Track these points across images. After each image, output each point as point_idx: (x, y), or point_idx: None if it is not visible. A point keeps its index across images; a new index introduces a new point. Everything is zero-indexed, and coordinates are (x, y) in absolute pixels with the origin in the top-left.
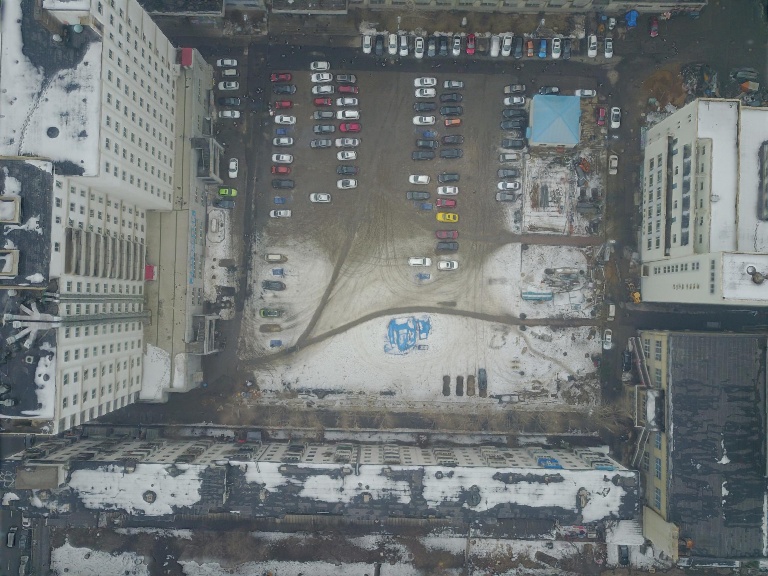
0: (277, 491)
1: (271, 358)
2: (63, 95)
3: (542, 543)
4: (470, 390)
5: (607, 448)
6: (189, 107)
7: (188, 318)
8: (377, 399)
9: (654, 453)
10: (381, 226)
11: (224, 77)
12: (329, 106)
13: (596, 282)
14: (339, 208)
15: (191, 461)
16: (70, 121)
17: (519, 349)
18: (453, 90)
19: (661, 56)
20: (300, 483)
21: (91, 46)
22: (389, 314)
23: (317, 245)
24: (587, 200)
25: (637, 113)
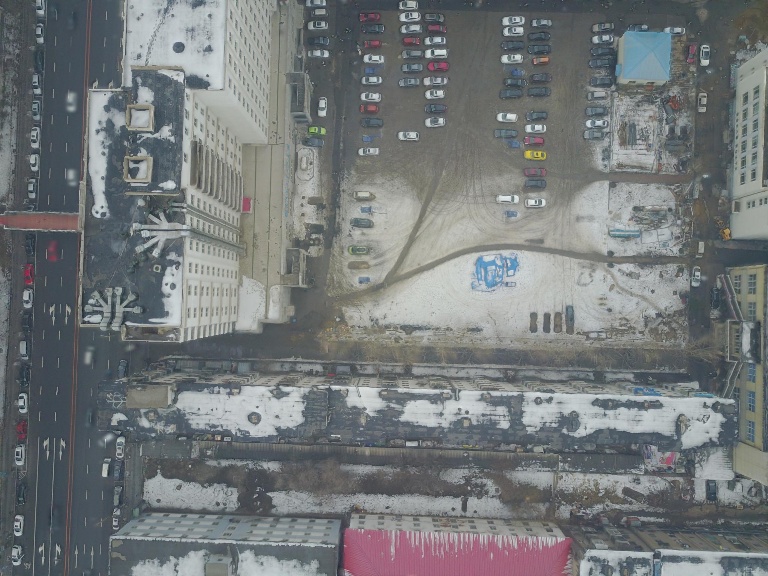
0: (378, 415)
1: (359, 294)
2: (188, 11)
3: (629, 479)
4: (557, 327)
5: (696, 384)
6: (284, 43)
7: (283, 250)
8: (464, 335)
9: (746, 387)
10: (468, 164)
11: (313, 17)
12: (417, 45)
13: (684, 220)
14: (427, 146)
15: (293, 385)
16: (195, 36)
17: (606, 286)
18: (541, 29)
19: None
20: (400, 408)
21: None
22: (476, 251)
23: (405, 183)
24: (675, 138)
25: (726, 51)
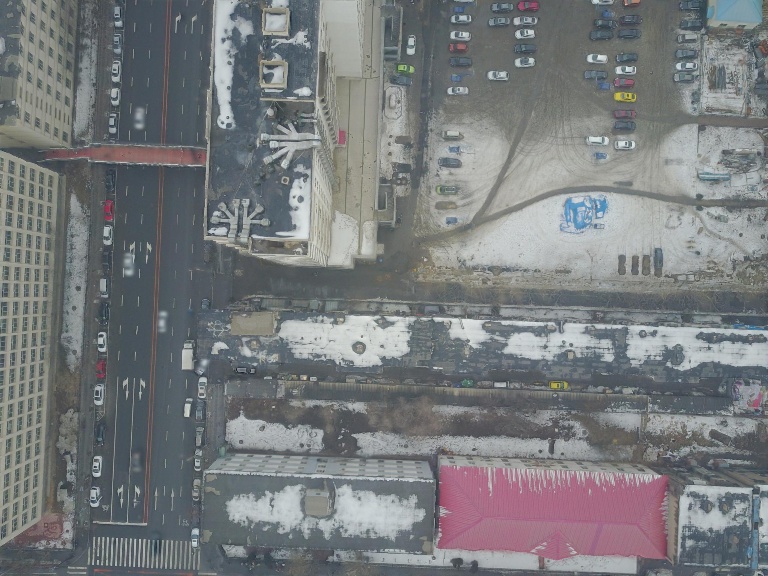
0: (481, 347)
1: (446, 235)
2: None
3: (716, 421)
4: (645, 269)
5: None
6: None
7: (378, 185)
8: (553, 277)
9: None
10: (558, 105)
11: None
12: None
13: None
14: (516, 87)
15: None
16: None
17: (695, 229)
18: None
19: None
20: (504, 340)
21: None
22: (565, 193)
23: (494, 123)
24: (765, 82)
25: None
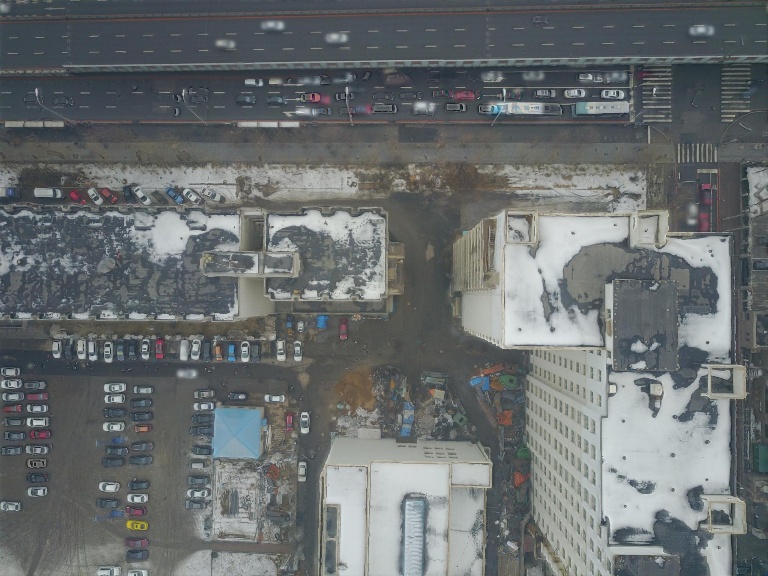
0: None
1: None
2: None
3: None
4: None
5: None
6: None
7: None
8: None
9: None
10: (72, 533)
11: None
12: (19, 412)
13: None
14: (31, 515)
15: None
16: None
17: None
18: (143, 394)
19: (352, 359)
20: None
21: None
22: None
23: (9, 552)
24: (277, 507)
25: (328, 417)
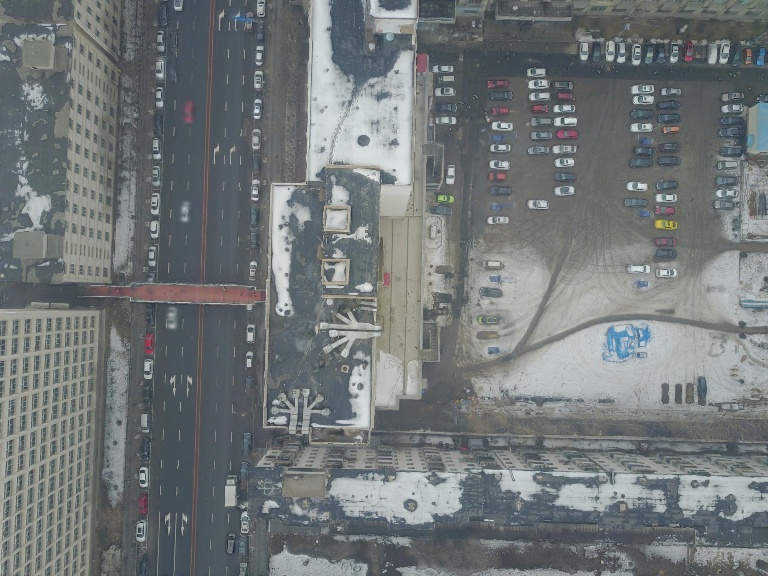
0: (532, 500)
1: (488, 365)
2: (374, 103)
3: (763, 551)
4: (689, 398)
5: None
6: (420, 113)
7: (422, 325)
8: (596, 407)
9: None
10: (598, 233)
11: (441, 83)
12: (546, 113)
13: None
14: (556, 215)
15: (444, 469)
16: (381, 129)
17: (738, 357)
18: (670, 97)
19: None
20: (555, 492)
21: (401, 54)
22: (607, 321)
23: (534, 252)
24: None
25: None
